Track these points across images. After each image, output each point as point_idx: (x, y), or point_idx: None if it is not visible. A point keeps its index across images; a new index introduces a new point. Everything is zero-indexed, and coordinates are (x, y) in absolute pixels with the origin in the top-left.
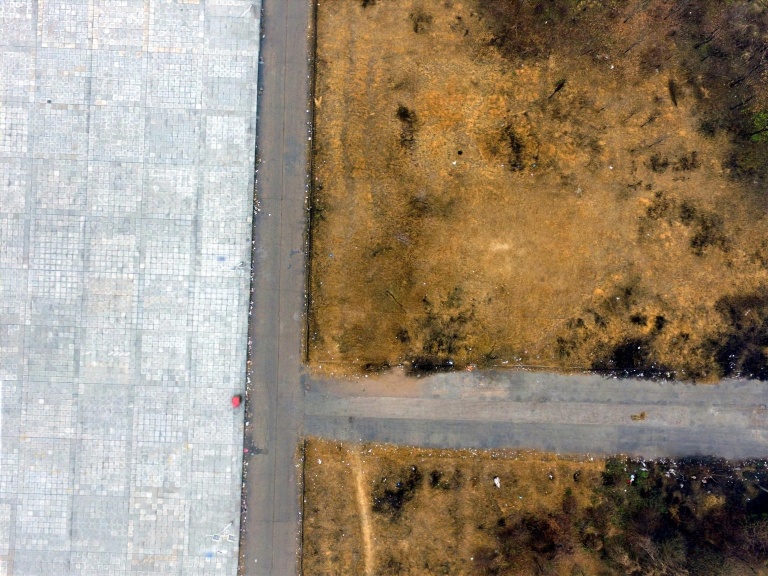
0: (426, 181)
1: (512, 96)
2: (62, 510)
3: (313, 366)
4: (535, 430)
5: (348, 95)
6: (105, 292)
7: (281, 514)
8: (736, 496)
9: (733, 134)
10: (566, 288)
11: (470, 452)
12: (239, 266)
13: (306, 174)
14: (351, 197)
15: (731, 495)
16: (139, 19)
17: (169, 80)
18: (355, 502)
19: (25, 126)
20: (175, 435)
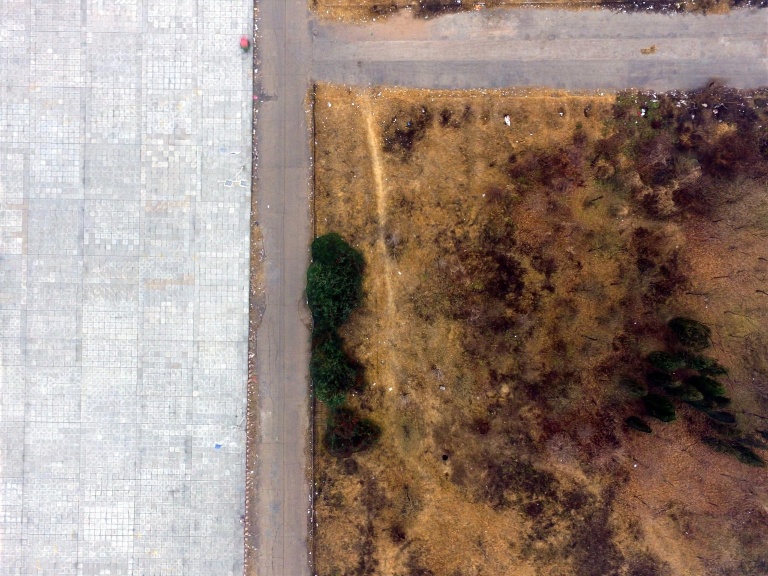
0: None
1: None
2: (74, 159)
3: (320, 11)
4: (545, 68)
5: None
6: None
7: (292, 160)
8: (748, 123)
9: None
10: None
11: (480, 92)
12: None
13: None
14: None
15: (743, 123)
16: None
17: None
18: (366, 143)
19: None
20: (184, 82)
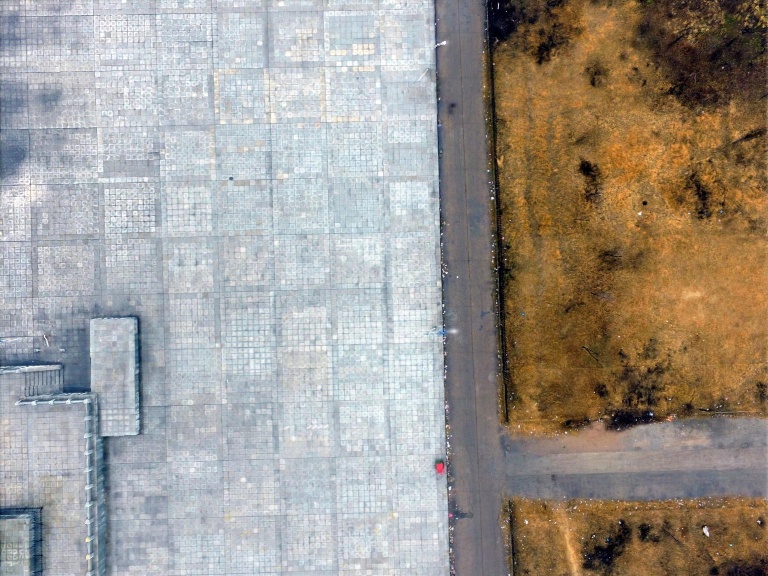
0: (613, 234)
1: (694, 143)
2: None
3: (512, 426)
4: (740, 476)
5: (530, 153)
6: (299, 366)
7: None
8: None
9: None
10: (761, 332)
11: (676, 502)
12: (432, 331)
13: (491, 234)
14: (539, 254)
15: None
16: (316, 90)
17: (350, 149)
18: (565, 560)
19: (208, 205)
20: (380, 505)
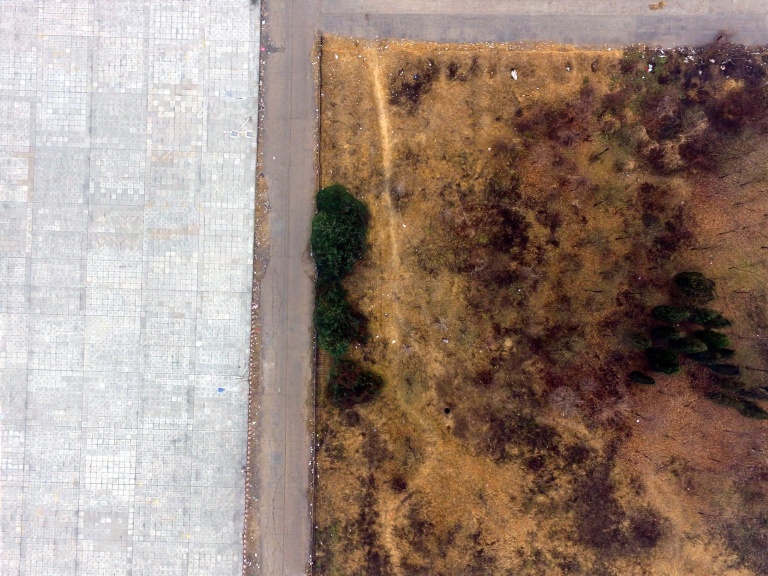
0: None
1: None
2: (81, 107)
3: None
4: (552, 22)
5: None
6: None
7: (298, 111)
8: (755, 80)
9: None
10: None
11: (487, 45)
12: None
13: None
14: None
15: (750, 79)
16: None
17: None
18: (372, 95)
19: None
20: (192, 32)
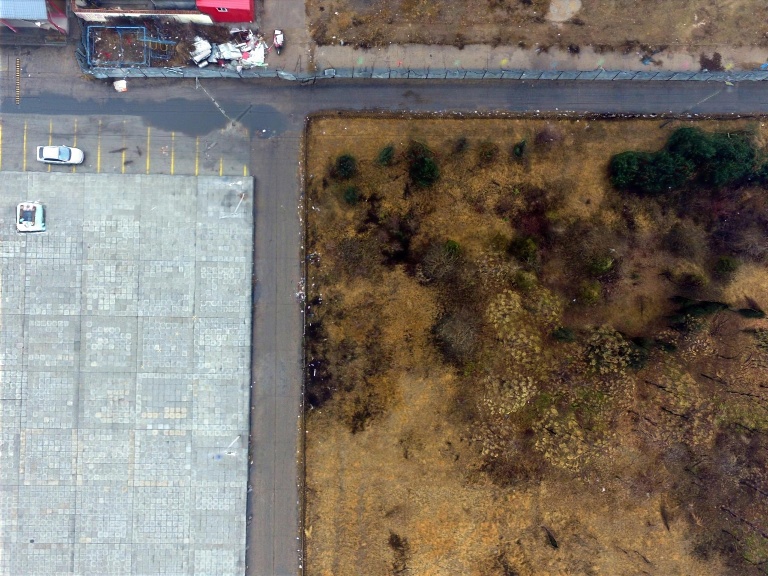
0: None
1: (504, 523)
2: None
3: None
4: None
5: (339, 525)
6: None
7: None
8: None
9: (726, 557)
10: None
11: None
12: None
13: None
14: None
15: None
16: (124, 453)
17: (156, 515)
18: None
19: (7, 567)
20: None
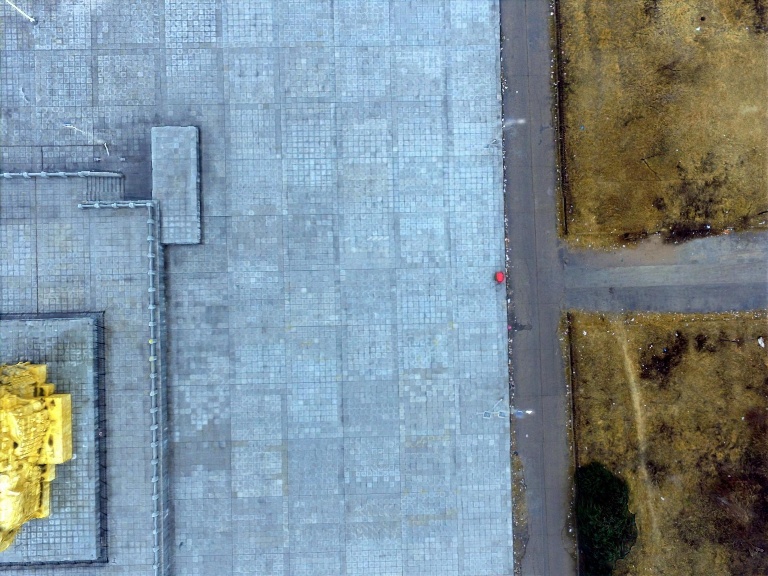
0: (672, 48)
1: None
2: (332, 397)
3: (570, 239)
4: None
5: None
6: (360, 178)
7: (549, 388)
8: None
9: None
10: None
11: (732, 314)
12: (492, 144)
13: (550, 49)
14: (598, 69)
15: None
16: None
17: None
18: (623, 370)
19: (269, 15)
20: (440, 316)
